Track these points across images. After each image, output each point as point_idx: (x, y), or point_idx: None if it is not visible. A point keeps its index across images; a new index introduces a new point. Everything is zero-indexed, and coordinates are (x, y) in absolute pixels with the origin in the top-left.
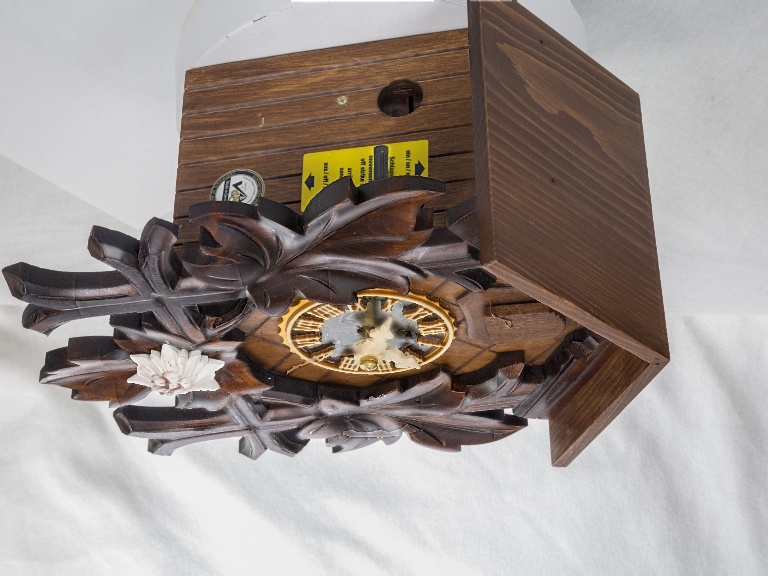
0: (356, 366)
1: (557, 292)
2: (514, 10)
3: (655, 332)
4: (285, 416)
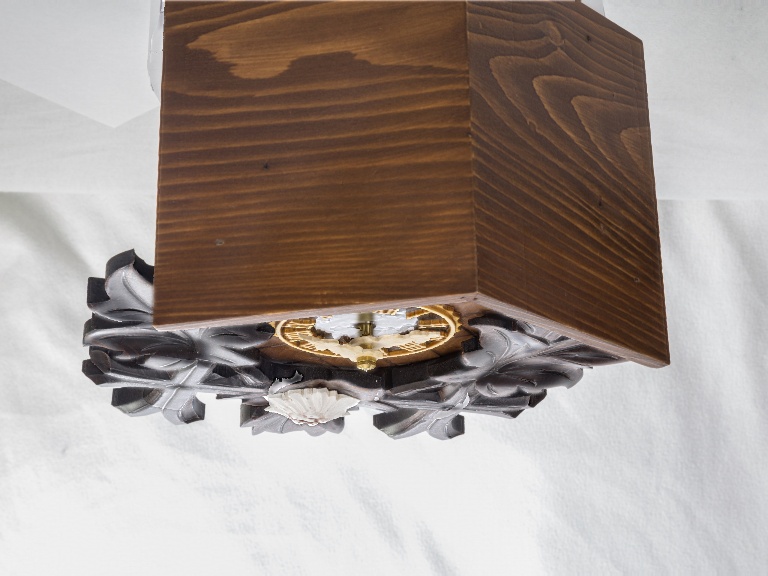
0: (417, 346)
1: (254, 311)
2: None
3: (448, 268)
4: (450, 393)
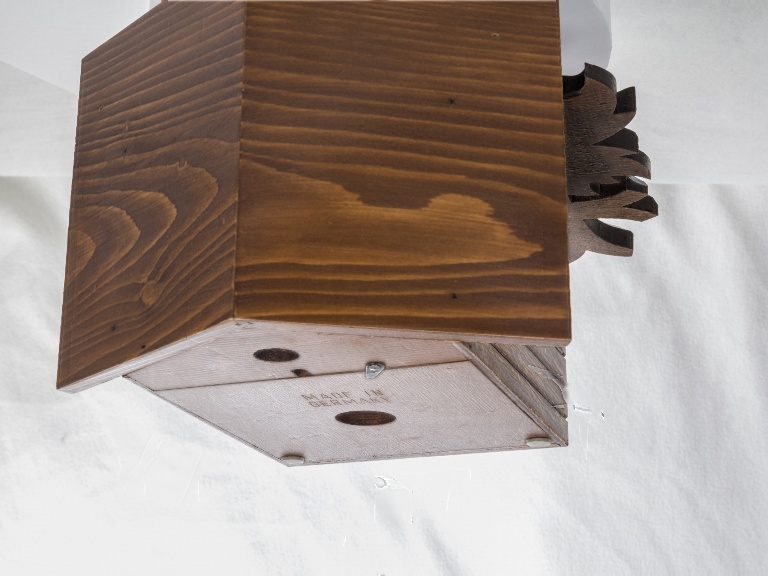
0: None
1: None
2: (507, 319)
3: None
4: None
